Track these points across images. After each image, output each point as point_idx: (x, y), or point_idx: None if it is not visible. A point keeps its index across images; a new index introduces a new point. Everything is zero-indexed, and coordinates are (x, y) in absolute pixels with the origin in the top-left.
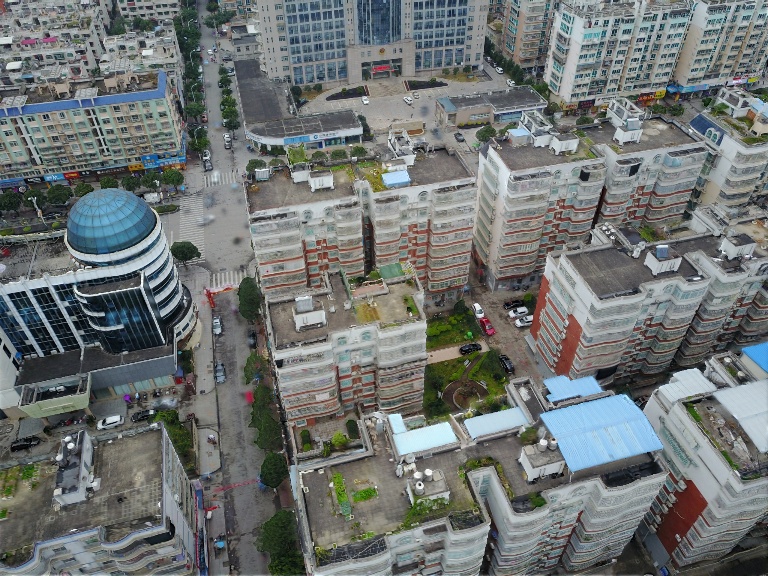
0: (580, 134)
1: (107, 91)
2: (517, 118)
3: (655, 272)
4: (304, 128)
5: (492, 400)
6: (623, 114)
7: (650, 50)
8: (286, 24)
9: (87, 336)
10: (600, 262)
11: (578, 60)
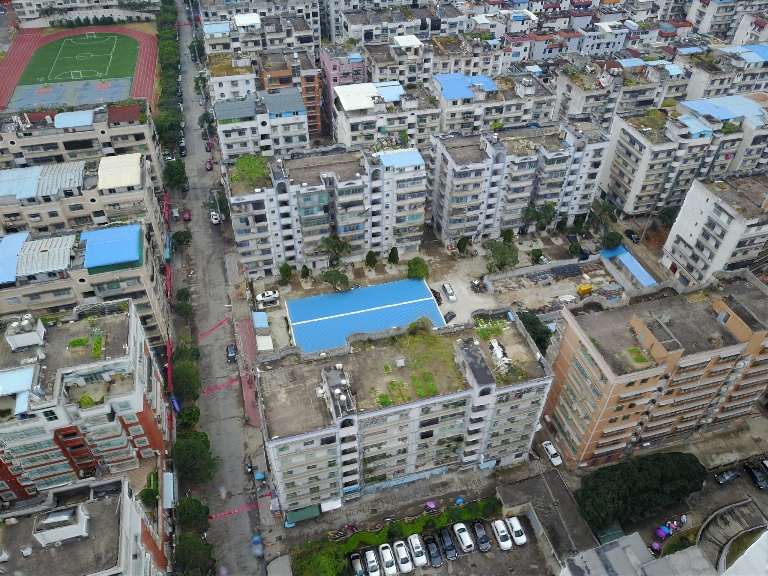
0: None
1: None
2: None
3: None
4: None
5: None
6: None
7: None
8: None
9: None
10: None
11: None
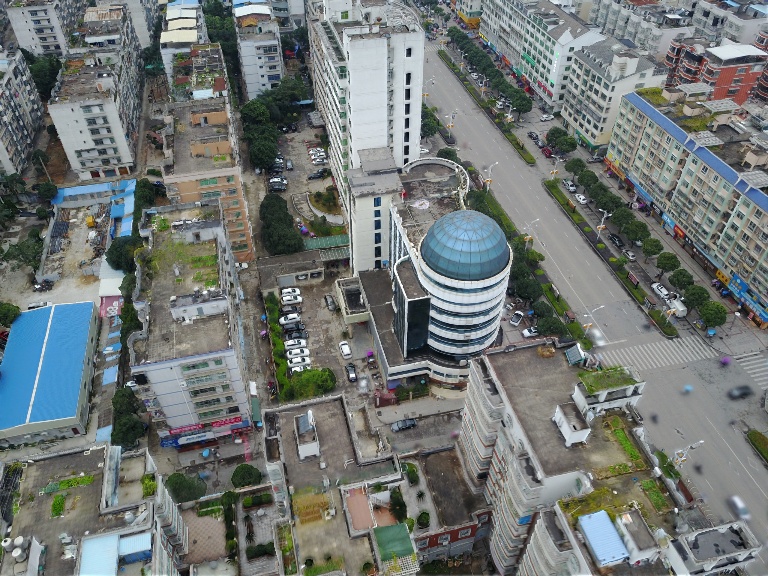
0: None
1: None
2: None
3: None
4: None
5: None
6: None
7: None
8: None
9: None
10: None
11: None
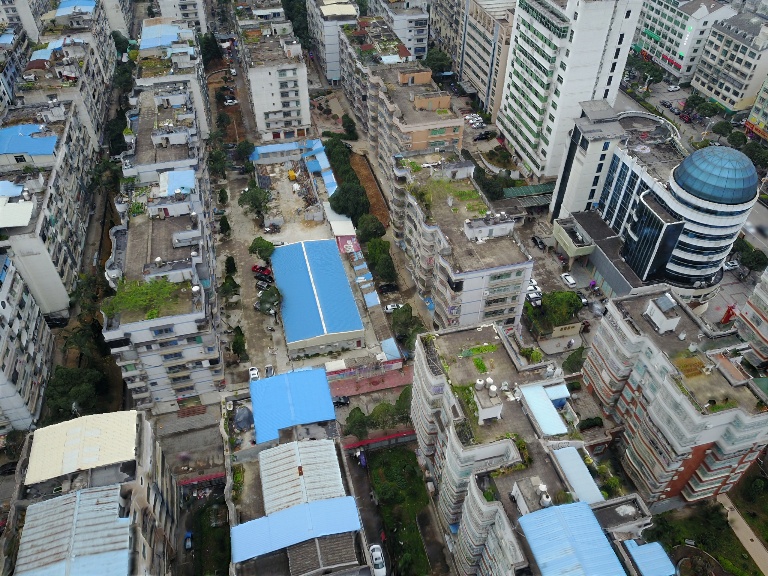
0: None
1: None
2: None
3: None
4: None
5: (612, 482)
6: None
7: None
8: None
9: None
10: None
11: None
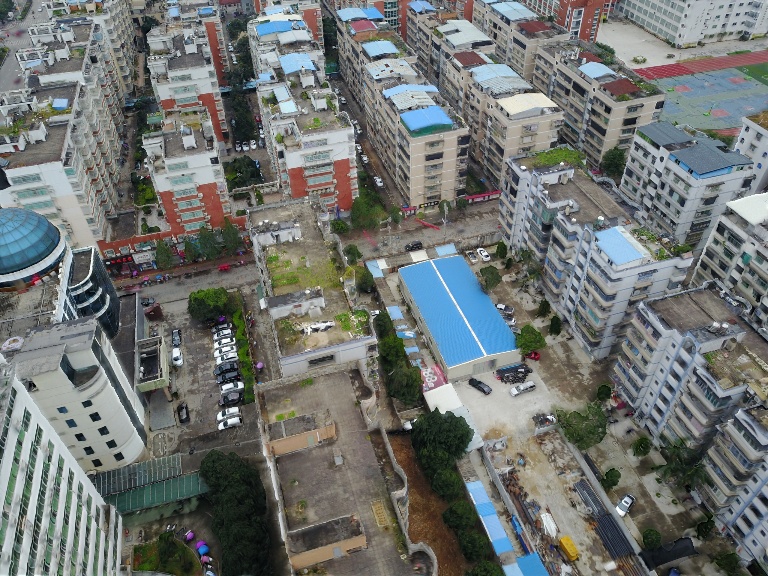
0: (50, 50)
1: None
2: None
3: (196, 51)
4: None
5: (265, 98)
6: None
7: None
8: None
9: None
10: None
11: None
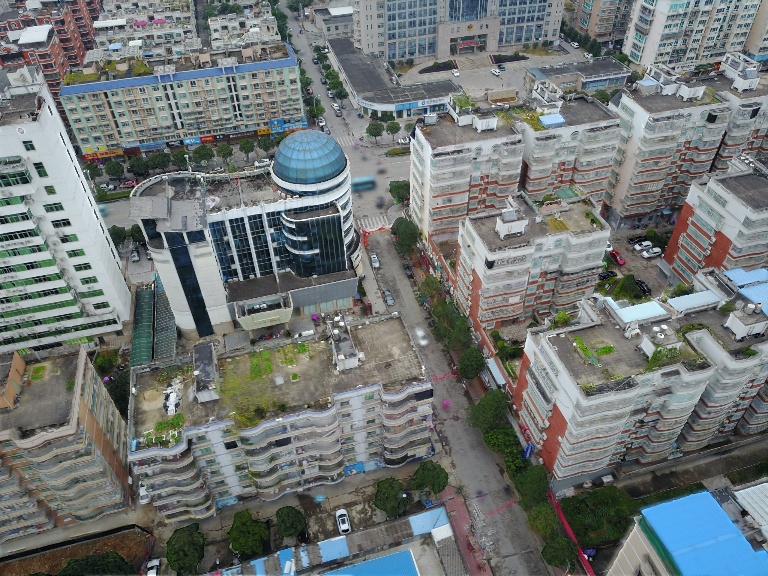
0: None
1: (243, 60)
2: (602, 86)
3: None
4: (410, 96)
5: (683, 287)
6: (739, 66)
7: (727, 20)
8: (385, 2)
9: (280, 262)
10: (745, 185)
11: (663, 30)
